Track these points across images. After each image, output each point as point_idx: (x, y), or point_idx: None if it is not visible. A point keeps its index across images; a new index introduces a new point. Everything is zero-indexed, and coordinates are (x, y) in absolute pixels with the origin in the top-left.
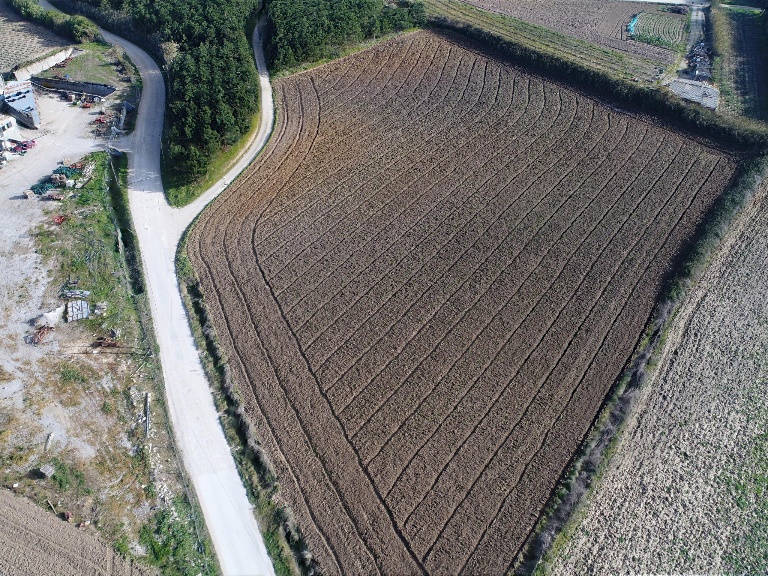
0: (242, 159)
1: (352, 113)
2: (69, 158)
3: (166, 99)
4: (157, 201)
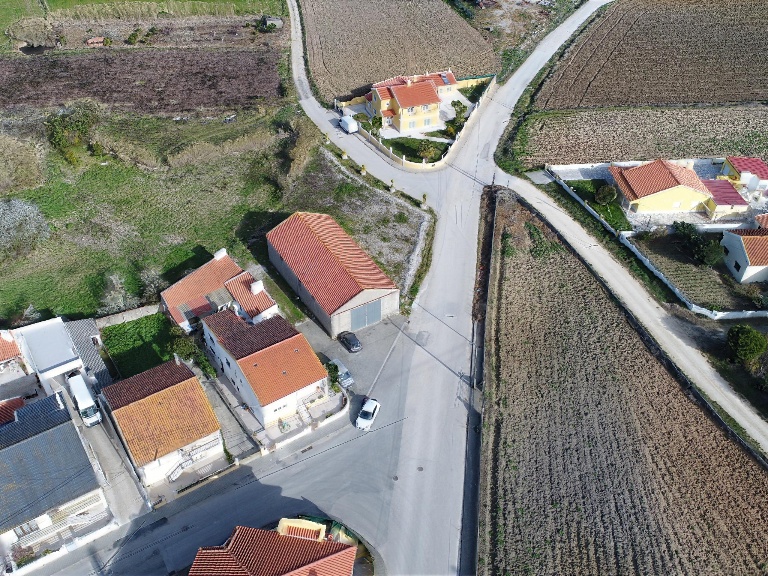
0: None
1: None
2: None
3: None
4: None
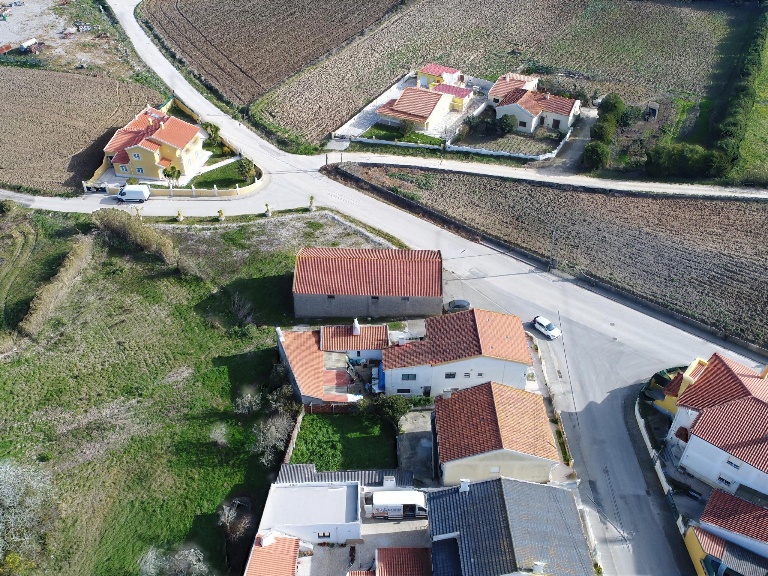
0: None
1: None
2: None
3: None
4: None
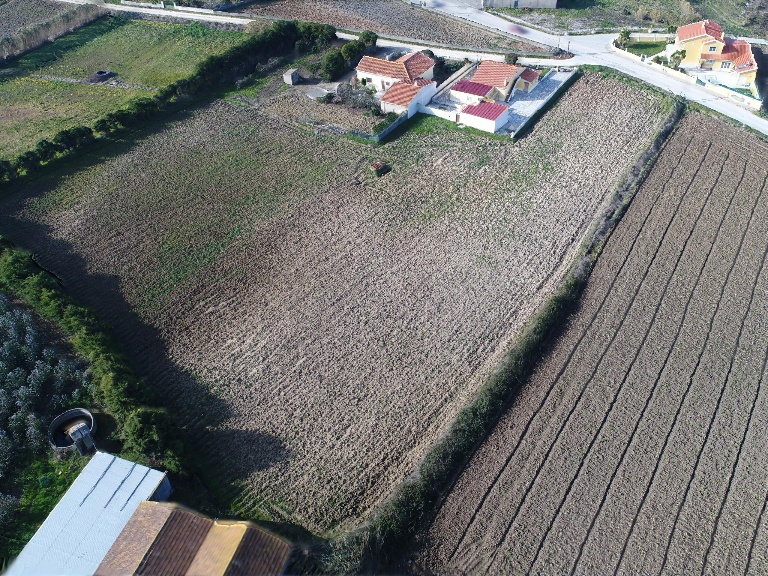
0: None
1: None
2: None
3: None
4: None
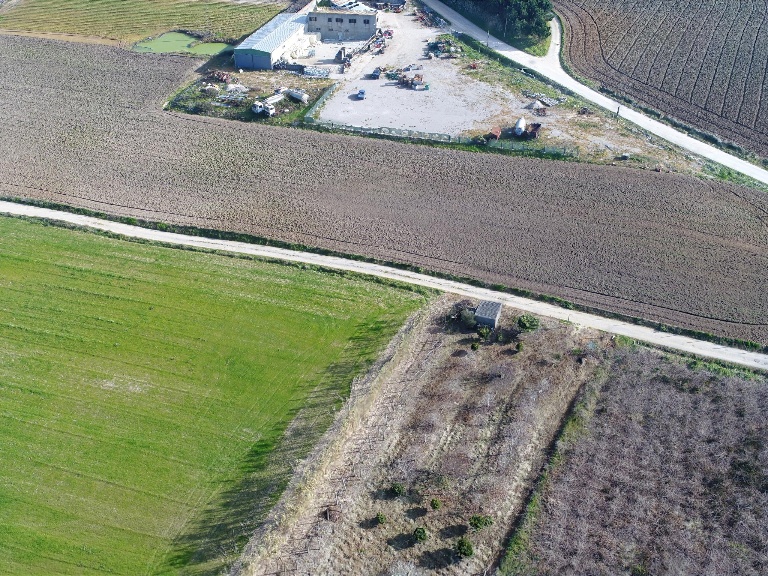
0: (553, 32)
1: (600, 4)
2: (430, 38)
3: (449, 5)
4: (523, 55)
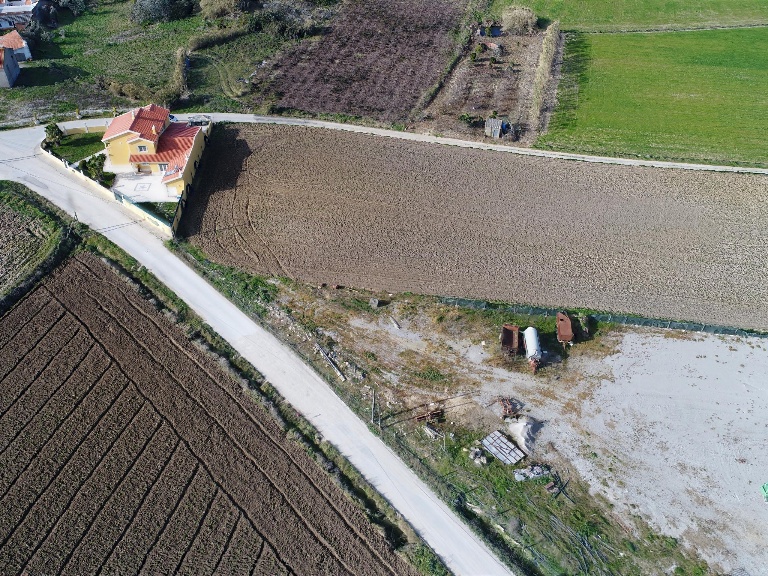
0: None
1: None
2: None
3: None
4: None
